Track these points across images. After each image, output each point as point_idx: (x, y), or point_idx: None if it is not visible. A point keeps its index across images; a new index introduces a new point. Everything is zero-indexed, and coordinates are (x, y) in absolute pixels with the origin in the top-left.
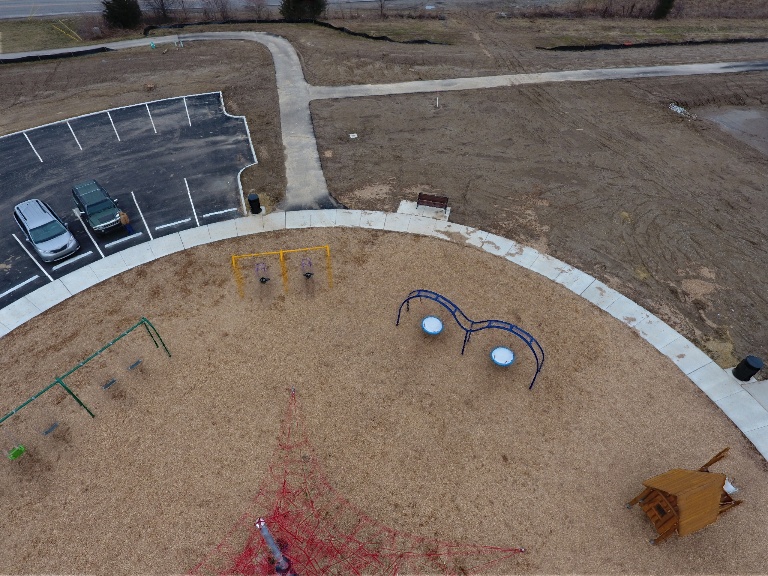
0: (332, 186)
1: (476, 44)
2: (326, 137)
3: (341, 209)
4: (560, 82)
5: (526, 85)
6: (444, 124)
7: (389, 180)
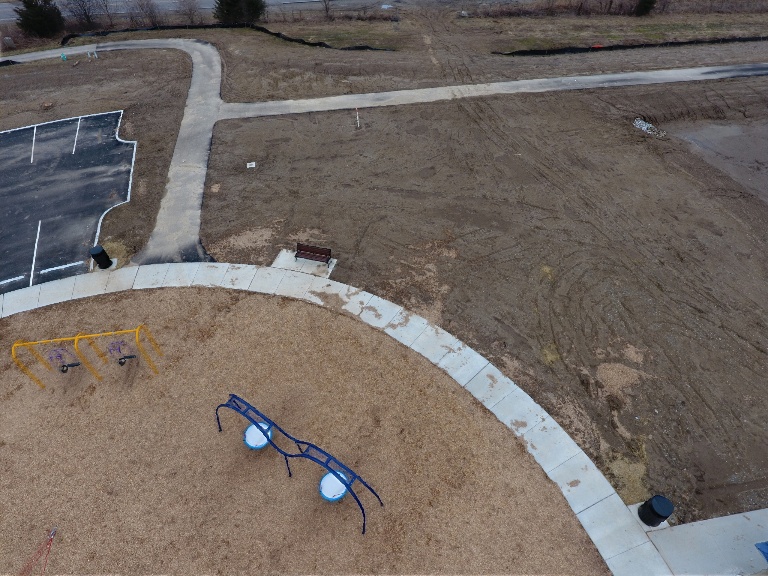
0: (205, 231)
1: (424, 49)
2: (219, 167)
3: (206, 262)
4: (510, 94)
5: (469, 98)
6: (360, 149)
7: (274, 223)
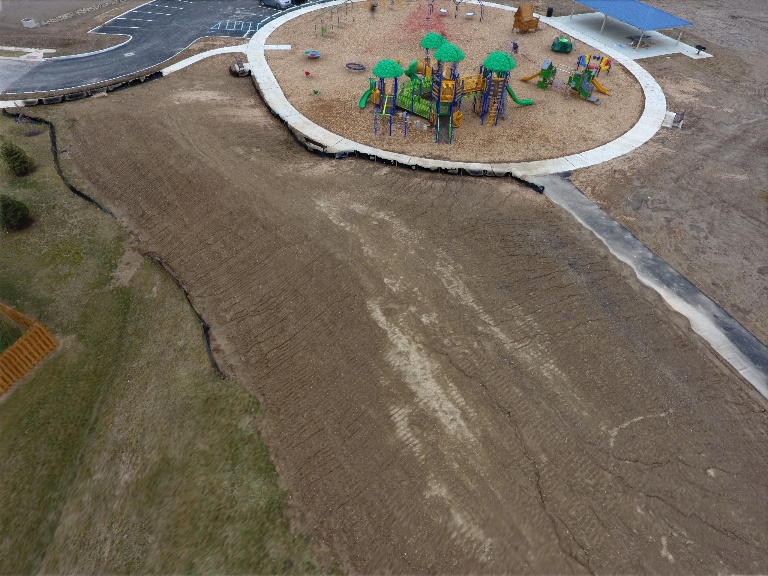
0: None
1: None
2: None
3: None
4: None
5: None
6: None
7: None
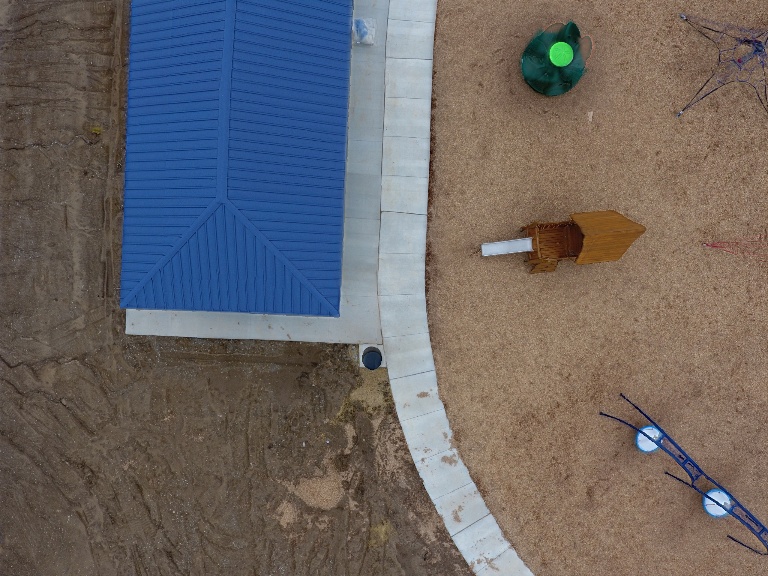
0: None
1: None
2: None
3: None
4: None
5: None
6: None
7: None
